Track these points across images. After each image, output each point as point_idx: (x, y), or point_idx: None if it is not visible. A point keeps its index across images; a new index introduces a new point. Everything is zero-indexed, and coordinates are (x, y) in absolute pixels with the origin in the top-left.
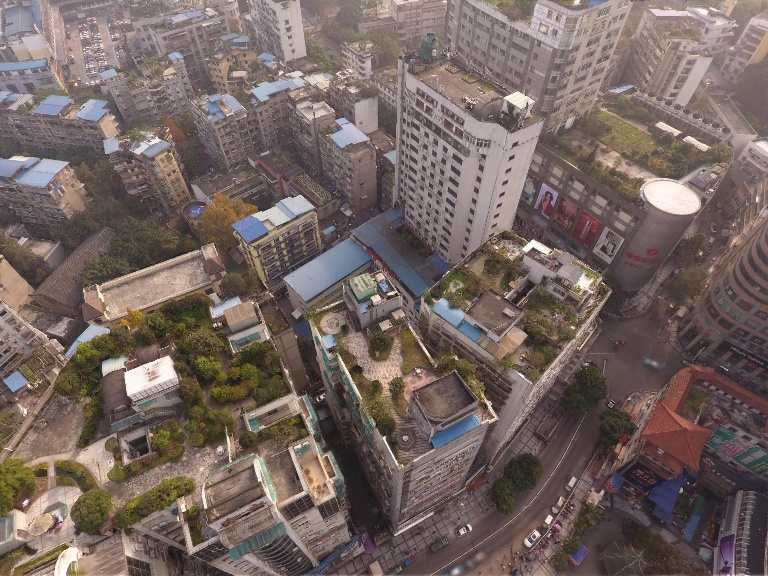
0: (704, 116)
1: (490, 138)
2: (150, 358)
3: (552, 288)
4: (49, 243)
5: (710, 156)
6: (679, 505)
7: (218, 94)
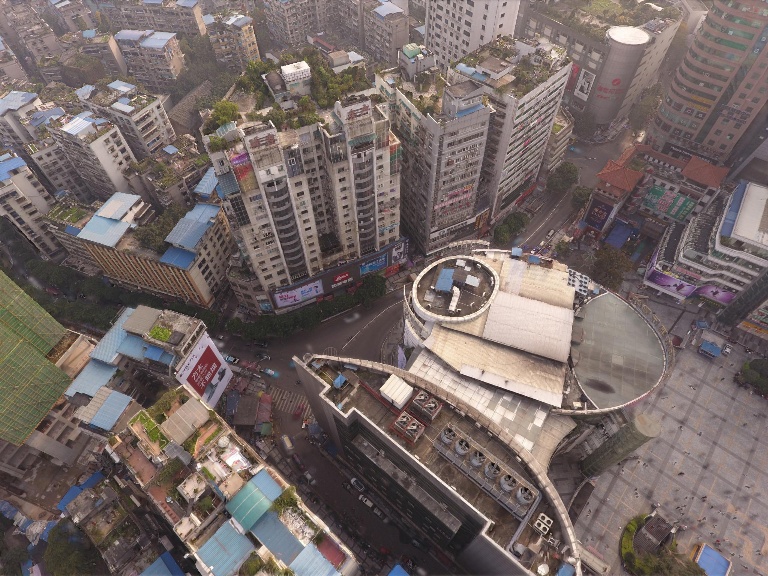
0: None
1: None
2: None
3: (533, 59)
4: (162, 95)
5: (663, 13)
6: (626, 247)
7: None
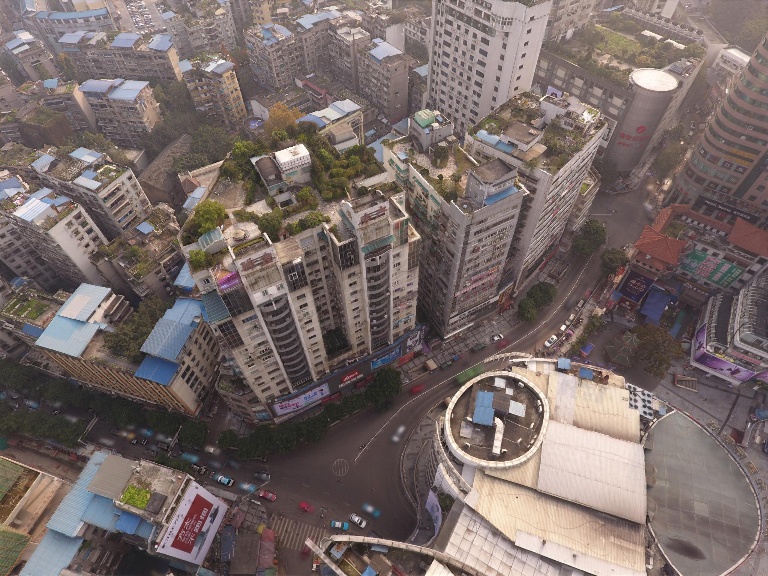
0: (681, 23)
1: (512, 16)
2: (289, 146)
3: (563, 122)
4: (135, 151)
5: (686, 52)
6: (665, 317)
7: (270, 23)
